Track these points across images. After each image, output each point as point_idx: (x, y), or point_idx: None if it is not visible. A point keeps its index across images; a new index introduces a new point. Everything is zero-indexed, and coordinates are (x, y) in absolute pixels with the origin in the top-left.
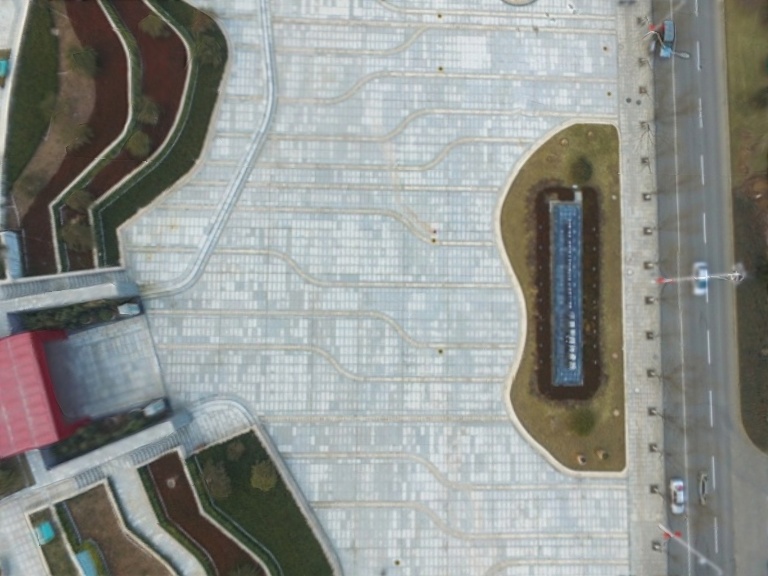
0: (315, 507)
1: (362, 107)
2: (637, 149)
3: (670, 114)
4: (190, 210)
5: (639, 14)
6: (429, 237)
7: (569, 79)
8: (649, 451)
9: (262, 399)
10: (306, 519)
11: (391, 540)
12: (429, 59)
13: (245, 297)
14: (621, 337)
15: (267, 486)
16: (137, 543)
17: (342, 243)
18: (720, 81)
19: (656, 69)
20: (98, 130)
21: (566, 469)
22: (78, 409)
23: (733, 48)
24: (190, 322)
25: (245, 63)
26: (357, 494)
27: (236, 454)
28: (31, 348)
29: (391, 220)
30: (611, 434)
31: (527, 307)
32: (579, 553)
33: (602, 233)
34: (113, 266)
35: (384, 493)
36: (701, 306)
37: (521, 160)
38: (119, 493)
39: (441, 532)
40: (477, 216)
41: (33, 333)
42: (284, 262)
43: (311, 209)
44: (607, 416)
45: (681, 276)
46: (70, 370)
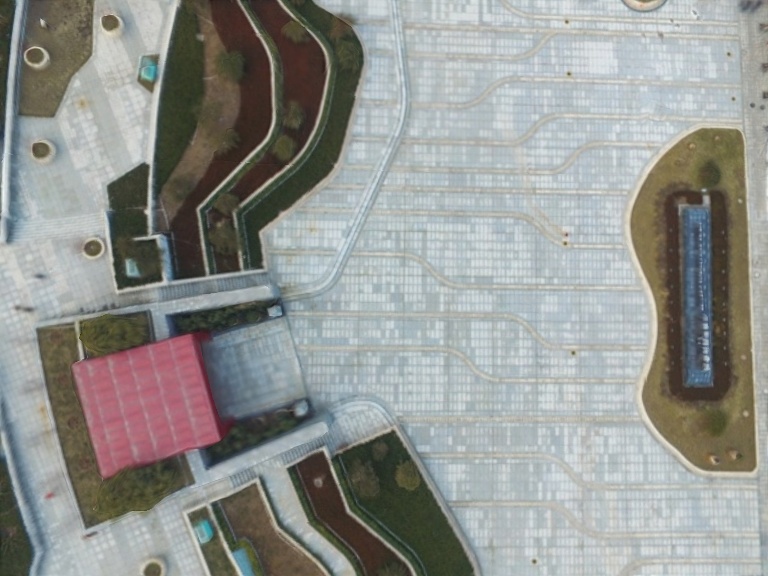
0: (453, 506)
1: (493, 112)
2: (762, 153)
3: None
4: (329, 213)
5: (761, 20)
6: (560, 240)
7: (694, 84)
8: None
9: (400, 400)
10: (447, 518)
11: (528, 539)
12: (557, 64)
13: (382, 299)
14: (749, 339)
15: (413, 486)
16: (289, 542)
17: (476, 246)
18: None
19: None
20: (244, 134)
21: (697, 469)
22: (222, 409)
23: None
24: (329, 324)
25: (379, 68)
26: (494, 494)
27: (381, 454)
28: (193, 349)
29: (523, 223)
30: (741, 435)
31: (658, 309)
32: (712, 552)
33: (730, 236)
34: (257, 268)
35: (520, 493)
36: None
37: (649, 164)
38: (270, 492)
39: (577, 531)
40: (607, 219)
41: (193, 335)
42: (420, 265)
43: (445, 212)
44: (737, 417)
45: None
46: (214, 371)
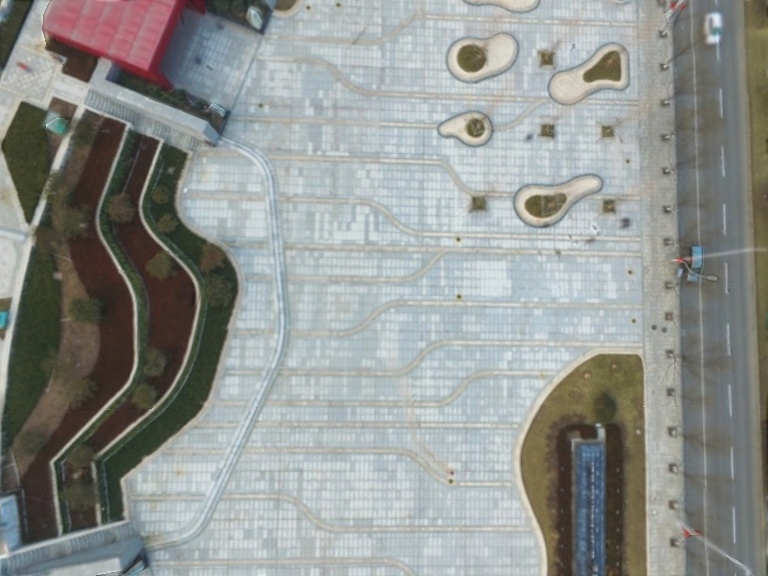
0: None
1: (377, 339)
2: (663, 380)
3: (697, 341)
4: (197, 455)
5: (665, 235)
6: (446, 478)
7: (592, 306)
8: None
9: None
10: None
11: None
12: (447, 286)
13: (254, 545)
14: None
15: None
16: None
17: (355, 485)
18: (749, 305)
19: (683, 294)
20: (102, 381)
21: None
22: None
23: (762, 271)
24: (196, 573)
25: (256, 295)
26: None
27: None
28: None
29: (407, 460)
30: None
31: (548, 552)
32: None
33: (626, 473)
34: (117, 521)
35: None
36: (728, 547)
37: (542, 395)
38: None
39: None
40: (496, 455)
41: None
42: (295, 507)
43: (323, 449)
44: None
45: (707, 515)
46: None
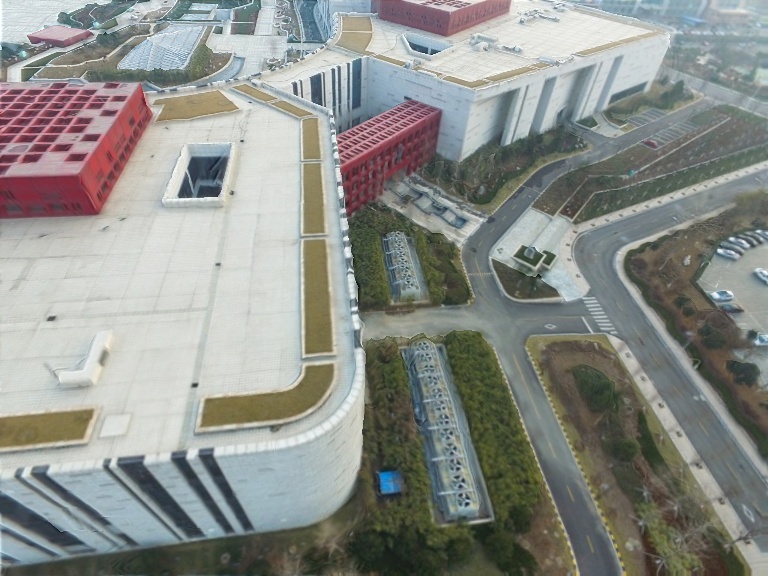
0: None
1: None
2: None
3: None
4: None
5: None
6: None
7: None
8: None
9: None
10: None
11: None
12: None
13: None
14: None
15: None
16: None
17: (42, 3)
18: None
19: None
20: None
21: None
22: None
23: None
24: None
25: None
26: None
27: None
28: None
29: None
30: None
31: None
32: None
33: None
34: None
35: None
36: None
37: None
38: None
39: None
40: None
41: None
42: None
43: (48, 6)
44: None
45: None
46: None
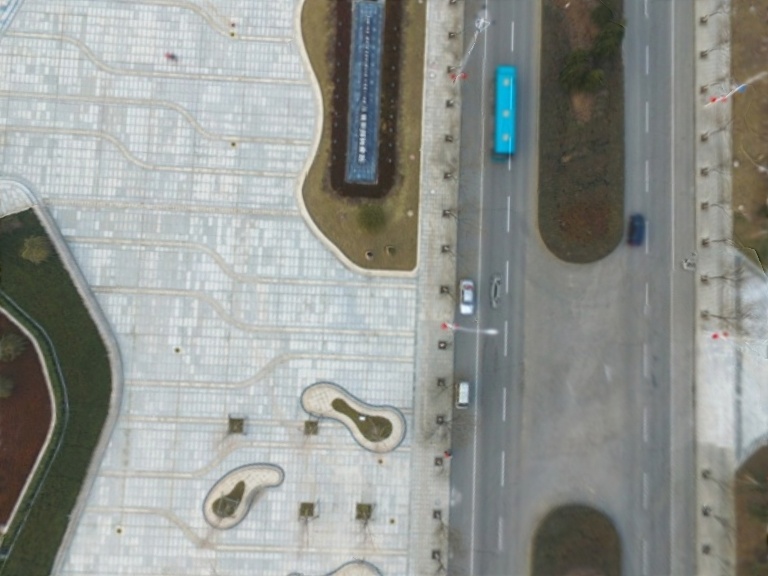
0: (96, 291)
1: None
2: None
3: None
4: None
5: None
6: (228, 31)
7: None
8: (441, 252)
9: (47, 182)
10: (83, 299)
11: (172, 328)
12: None
13: (35, 80)
14: (419, 139)
15: (38, 258)
16: None
17: (138, 33)
18: None
19: None
20: None
21: (356, 267)
22: None
23: None
24: None
25: None
26: (140, 281)
27: (9, 227)
28: None
29: (190, 13)
30: (404, 234)
31: (324, 104)
32: (364, 350)
33: (404, 34)
34: None
35: (167, 281)
36: (504, 113)
37: None
38: None
39: (224, 322)
40: (278, 12)
41: None
42: (77, 48)
43: None
44: (400, 216)
45: (485, 82)
46: None
